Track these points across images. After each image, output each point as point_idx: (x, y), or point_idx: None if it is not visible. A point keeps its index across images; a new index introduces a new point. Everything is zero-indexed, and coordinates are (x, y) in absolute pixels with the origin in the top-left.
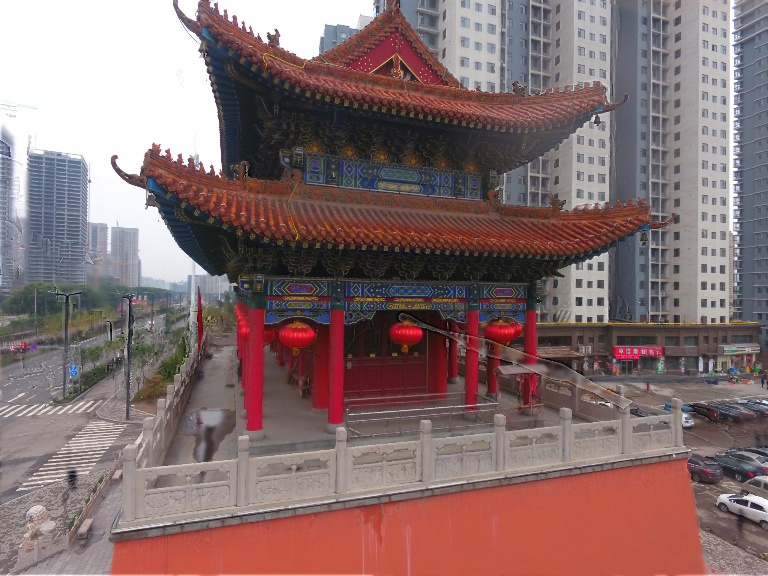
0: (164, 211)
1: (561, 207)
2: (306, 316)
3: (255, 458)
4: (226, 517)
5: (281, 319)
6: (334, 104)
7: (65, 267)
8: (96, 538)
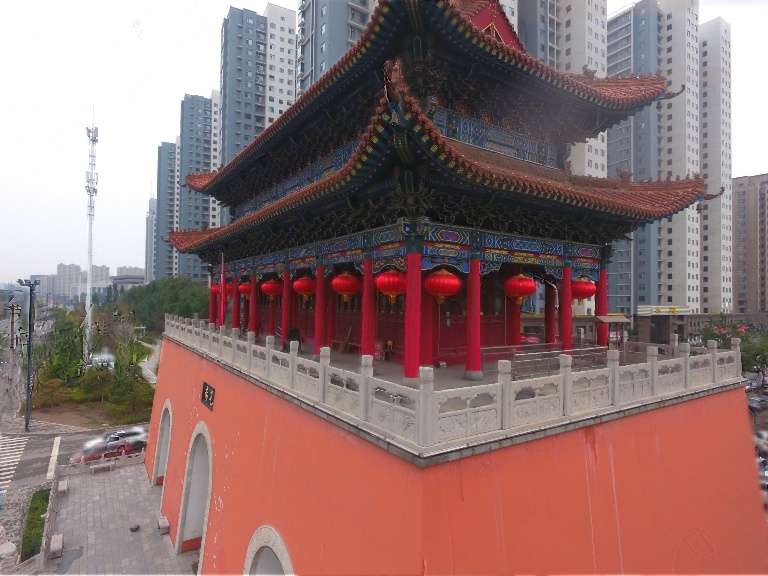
0: (379, 136)
1: (628, 179)
2: (452, 264)
3: (512, 382)
4: (500, 439)
5: (433, 266)
6: (483, 56)
7: None
8: (74, 554)
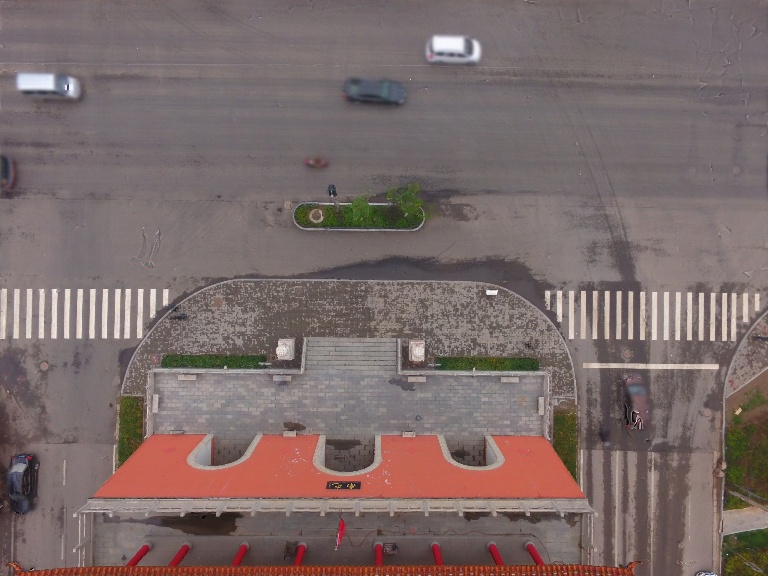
0: None
1: None
2: None
3: None
4: None
5: None
6: None
7: None
8: (407, 386)
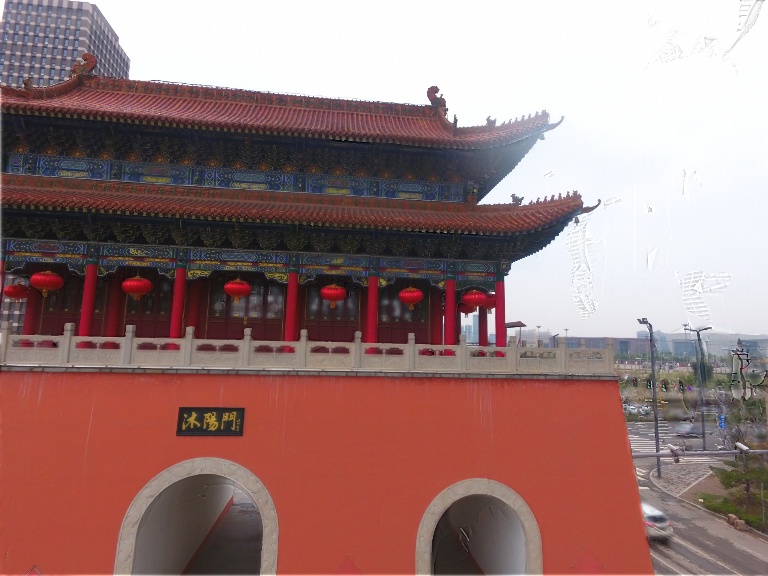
0: None
1: None
2: None
3: None
4: None
5: None
6: None
7: (687, 300)
8: None
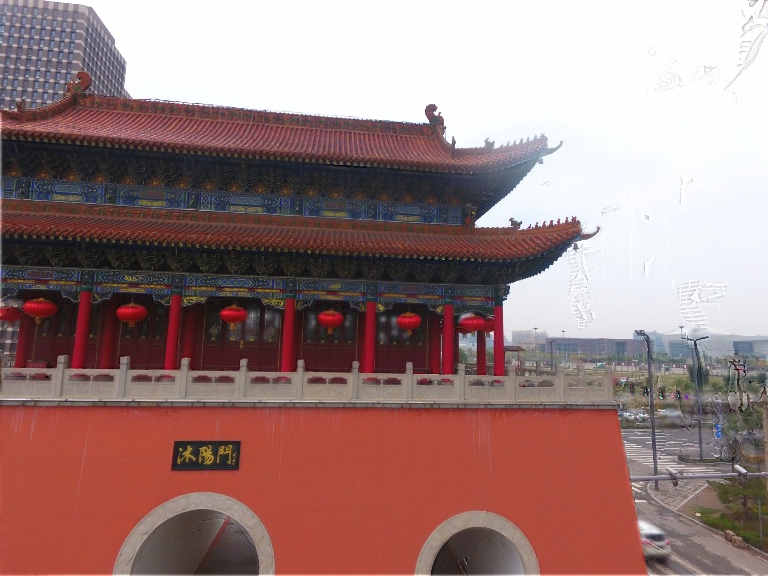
0: None
1: None
2: None
3: None
4: None
5: None
6: None
7: (684, 309)
8: None
